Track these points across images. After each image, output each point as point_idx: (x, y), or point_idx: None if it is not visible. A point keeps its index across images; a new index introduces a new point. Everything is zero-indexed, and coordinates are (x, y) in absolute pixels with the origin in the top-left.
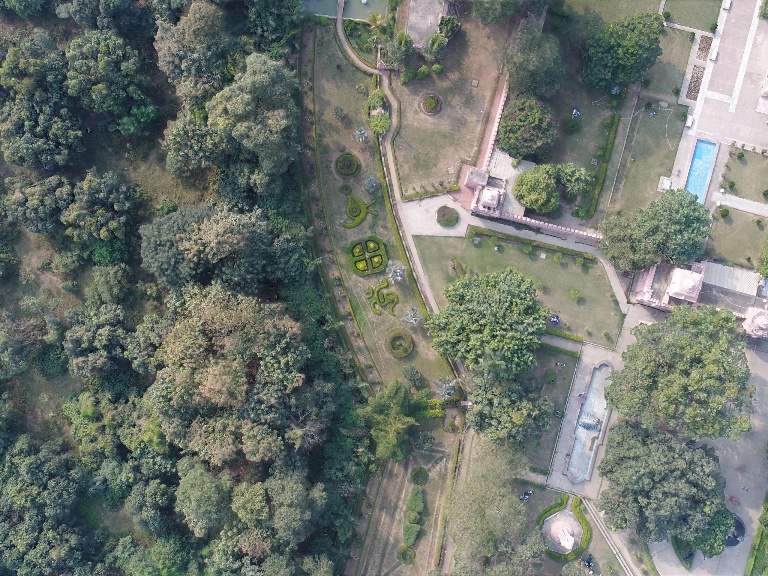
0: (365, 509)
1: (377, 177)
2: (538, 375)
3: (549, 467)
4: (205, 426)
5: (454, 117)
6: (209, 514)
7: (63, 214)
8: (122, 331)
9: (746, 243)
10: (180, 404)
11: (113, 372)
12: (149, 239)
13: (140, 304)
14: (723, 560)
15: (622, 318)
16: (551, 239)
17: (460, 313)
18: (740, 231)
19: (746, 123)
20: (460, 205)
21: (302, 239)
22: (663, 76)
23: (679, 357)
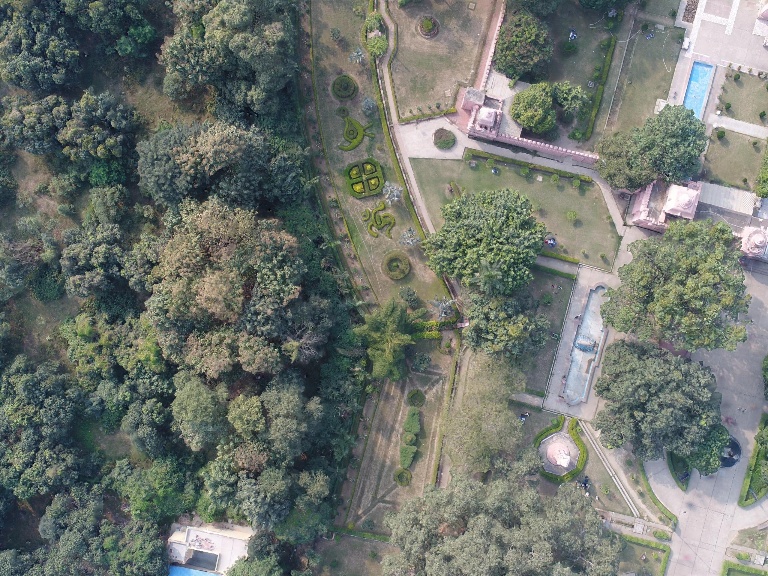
0: (362, 431)
1: (374, 100)
2: (535, 298)
3: (545, 389)
4: (201, 339)
5: (451, 40)
6: (205, 427)
7: (60, 133)
8: (119, 249)
9: (742, 165)
10: (177, 316)
11: (110, 295)
12: (146, 155)
13: (137, 228)
14: (719, 481)
15: (618, 240)
16: (548, 162)
17: (456, 229)
18: (736, 153)
19: (742, 45)
20: (457, 128)
21: (299, 159)
22: None
23: (675, 268)
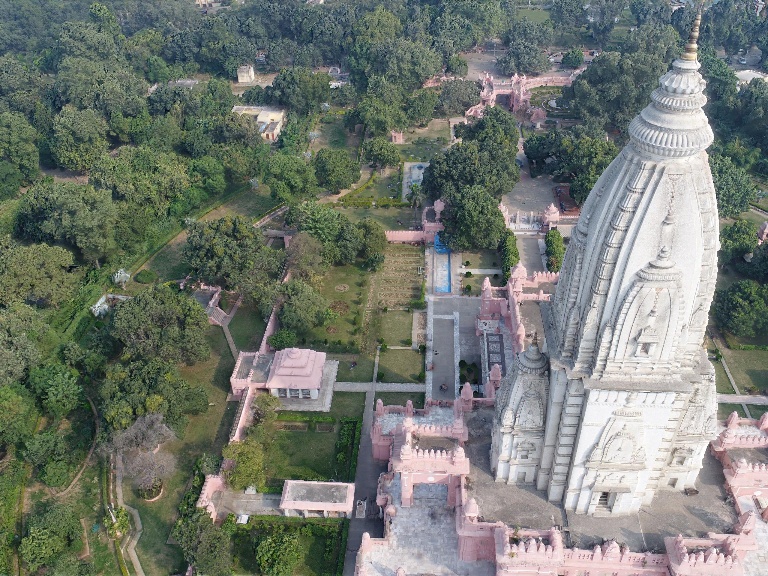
0: None
1: None
2: None
3: None
4: None
5: None
6: None
7: None
8: None
9: None
10: None
11: None
12: None
13: None
14: None
15: None
16: None
17: None
18: None
19: None
20: None
21: None
22: None
23: None
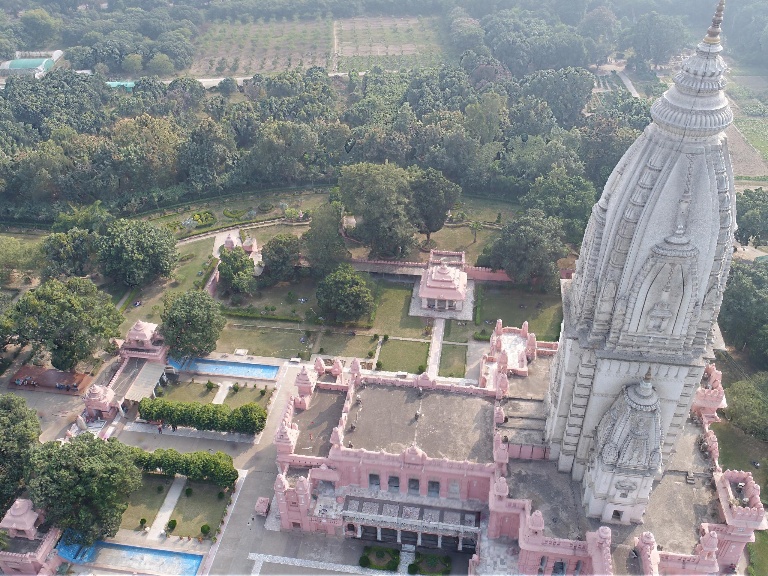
0: None
1: None
2: None
3: None
4: None
5: None
6: None
7: None
8: None
9: None
10: None
11: None
12: None
13: None
14: None
15: None
16: None
17: None
18: None
19: None
20: None
21: None
22: (336, 343)
23: None
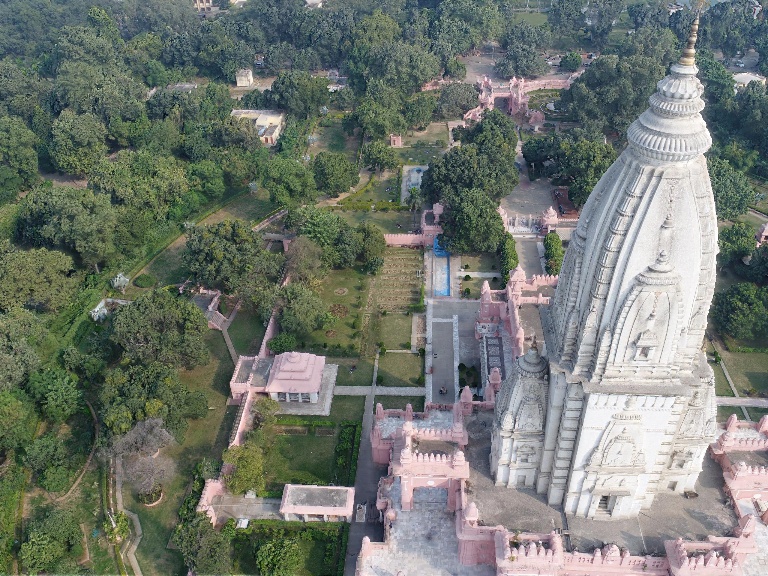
0: None
1: None
2: None
3: None
4: None
5: None
6: None
7: None
8: None
9: None
10: None
11: None
12: None
13: None
14: None
15: None
16: None
17: None
18: None
19: None
20: None
21: None
22: None
23: None
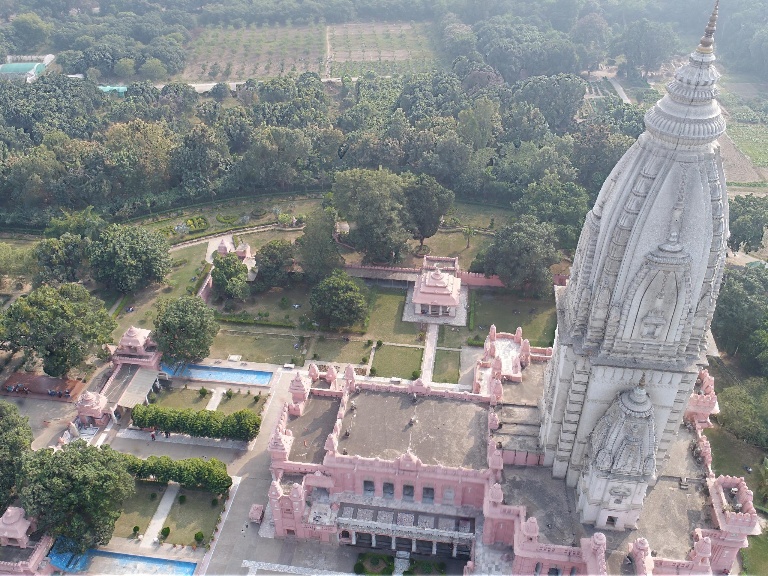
0: None
1: None
2: None
3: None
4: None
5: None
6: None
7: None
8: None
9: None
10: None
11: None
12: None
13: None
14: None
15: None
16: None
17: None
18: None
19: None
20: None
21: None
22: (329, 349)
23: None
